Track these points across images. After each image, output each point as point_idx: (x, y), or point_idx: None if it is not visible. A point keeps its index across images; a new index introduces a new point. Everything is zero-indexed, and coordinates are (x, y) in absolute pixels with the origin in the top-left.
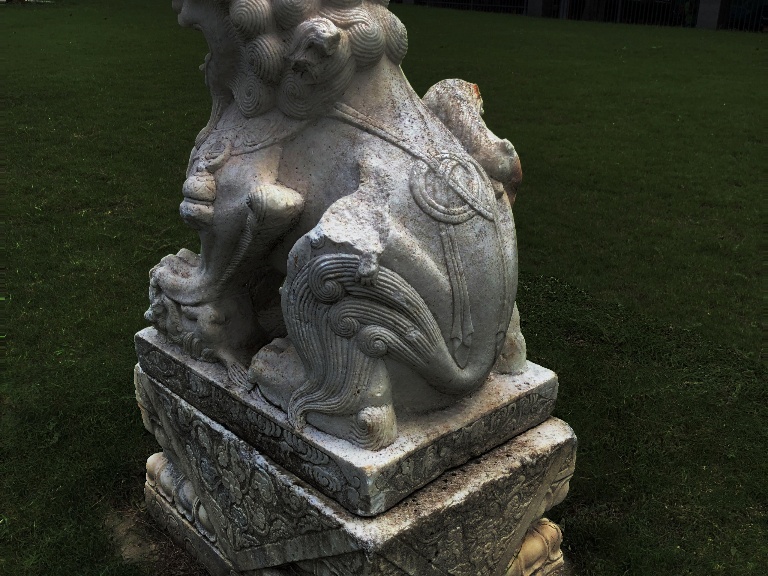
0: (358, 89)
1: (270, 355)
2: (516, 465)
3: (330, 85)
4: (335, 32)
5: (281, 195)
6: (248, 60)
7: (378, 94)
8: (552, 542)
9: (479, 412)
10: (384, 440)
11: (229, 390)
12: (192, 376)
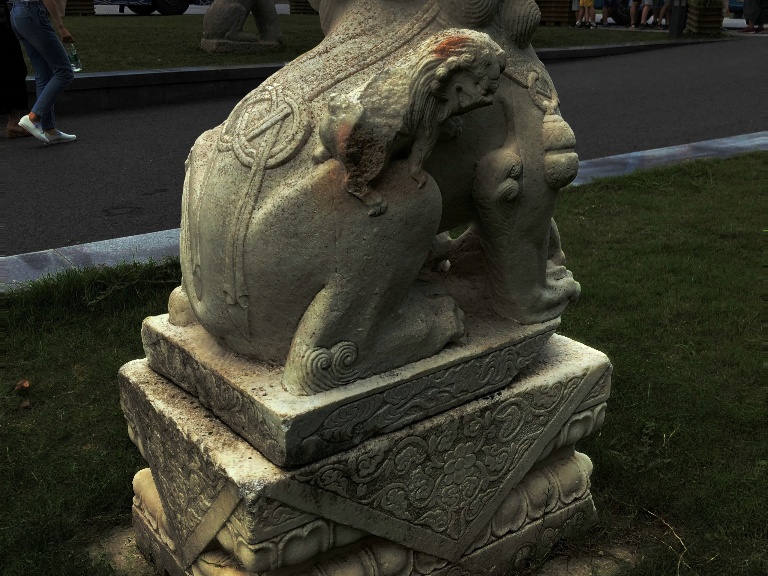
0: None
1: None
2: (193, 437)
3: None
4: None
5: None
6: None
7: (335, 26)
8: None
9: (212, 364)
10: None
11: None
12: None
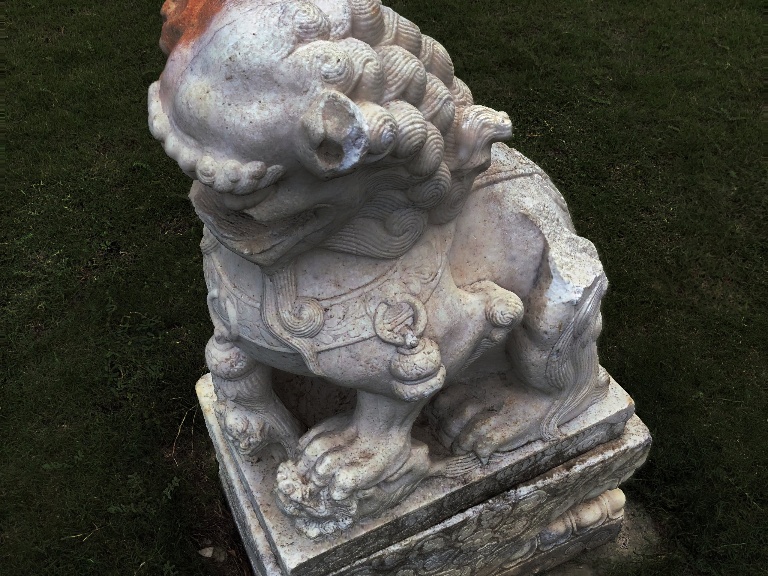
0: None
1: (493, 422)
2: None
3: None
4: None
5: None
6: (424, 200)
7: None
8: None
9: None
10: None
11: (471, 482)
12: (411, 517)
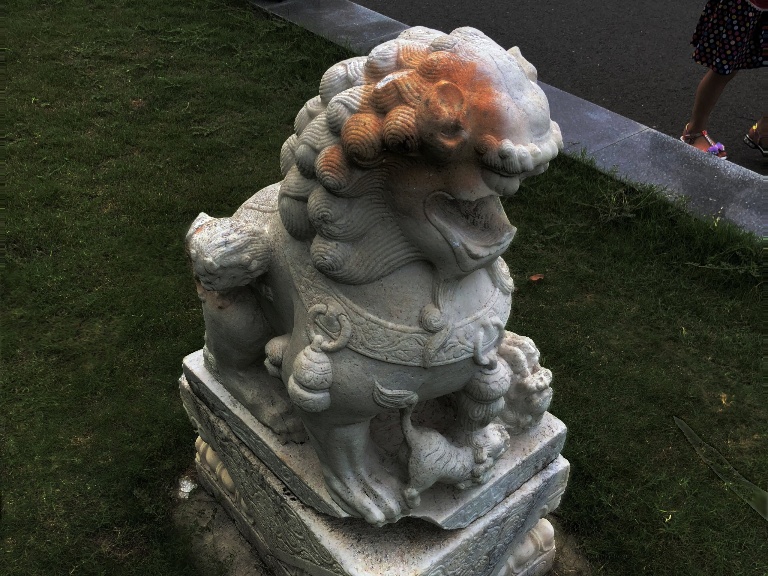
0: None
1: None
2: None
3: None
4: None
5: None
6: None
7: None
8: None
9: None
10: None
11: None
12: None
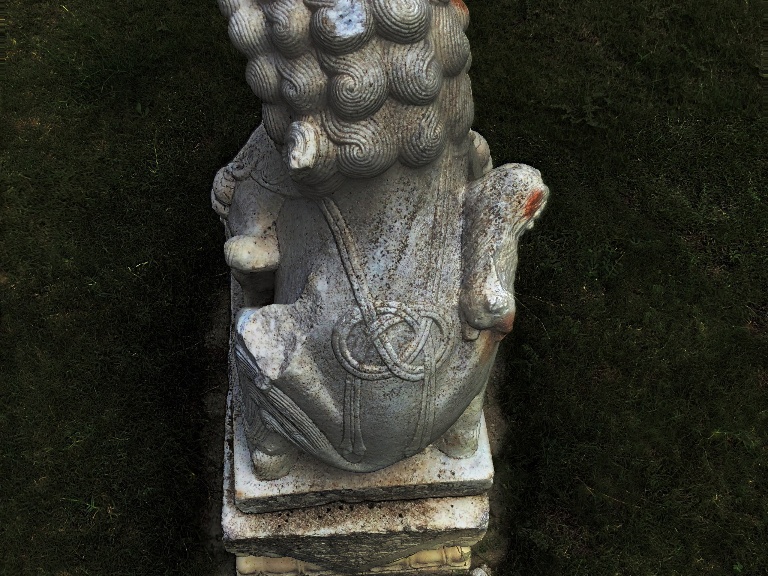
0: (350, 193)
1: None
2: (397, 529)
3: (314, 187)
4: (302, 165)
5: (249, 259)
6: None
7: (369, 206)
8: (454, 559)
9: (377, 484)
10: (268, 476)
11: (232, 330)
12: None
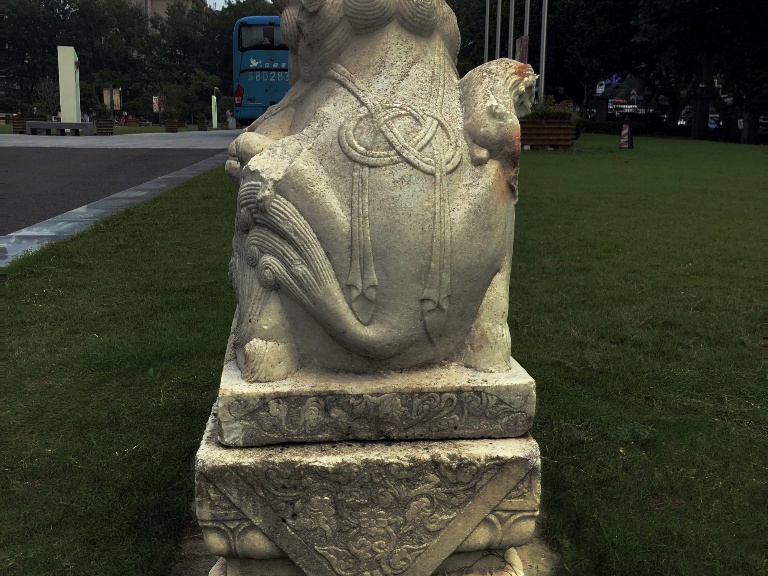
0: (355, 51)
1: None
2: (422, 457)
3: (323, 45)
4: None
5: (259, 141)
6: None
7: (372, 55)
8: None
9: (393, 385)
10: (261, 374)
11: None
12: None
